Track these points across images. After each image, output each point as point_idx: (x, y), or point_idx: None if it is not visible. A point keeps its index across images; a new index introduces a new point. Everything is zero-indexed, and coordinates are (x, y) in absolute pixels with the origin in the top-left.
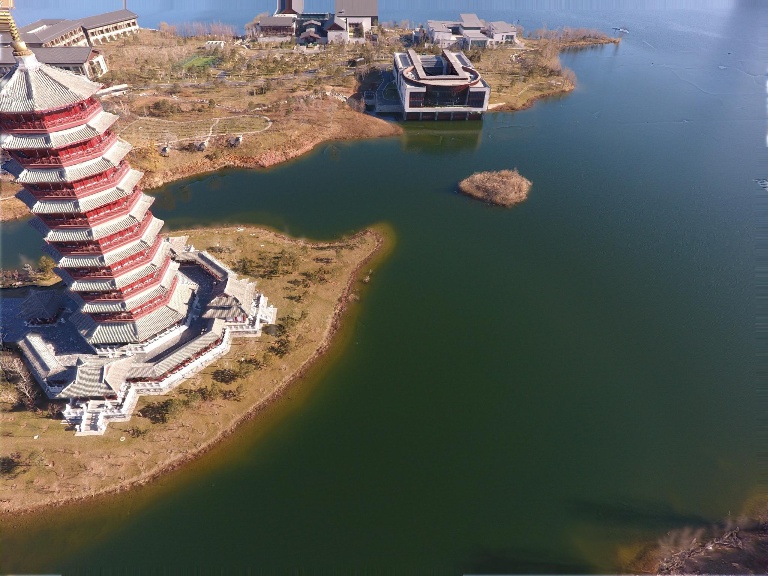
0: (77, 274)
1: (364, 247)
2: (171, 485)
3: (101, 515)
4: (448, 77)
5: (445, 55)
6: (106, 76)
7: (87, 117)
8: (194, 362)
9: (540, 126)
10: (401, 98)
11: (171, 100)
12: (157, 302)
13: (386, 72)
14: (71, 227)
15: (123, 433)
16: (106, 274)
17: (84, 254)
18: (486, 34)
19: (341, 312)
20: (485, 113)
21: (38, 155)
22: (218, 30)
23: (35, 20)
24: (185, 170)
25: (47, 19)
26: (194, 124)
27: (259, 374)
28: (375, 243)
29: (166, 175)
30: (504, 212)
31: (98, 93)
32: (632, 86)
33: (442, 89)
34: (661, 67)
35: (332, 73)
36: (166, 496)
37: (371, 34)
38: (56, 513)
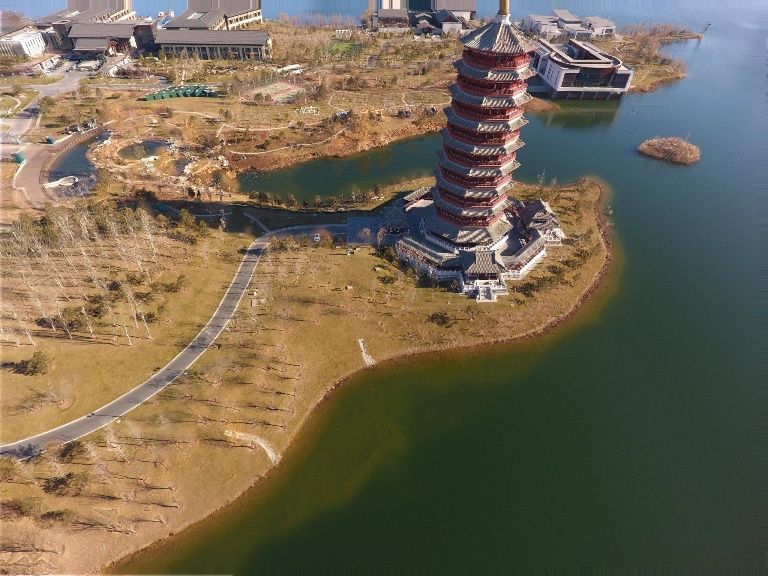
0: (472, 184)
1: (592, 191)
2: (560, 335)
3: (524, 351)
4: (594, 61)
5: (574, 44)
6: (276, 57)
7: None
8: (534, 258)
9: (674, 105)
10: (547, 80)
11: (348, 78)
12: (500, 214)
13: None
14: (491, 144)
15: (511, 301)
16: (492, 185)
17: (487, 167)
18: (585, 28)
19: (605, 234)
20: None
21: (495, 87)
22: (340, 20)
23: (187, 8)
24: (400, 133)
25: (196, 7)
26: (386, 97)
27: (577, 270)
28: (597, 188)
29: (387, 136)
30: (683, 170)
31: None
32: (735, 75)
33: (593, 71)
34: (753, 59)
35: None
36: (560, 342)
37: None
38: (492, 349)
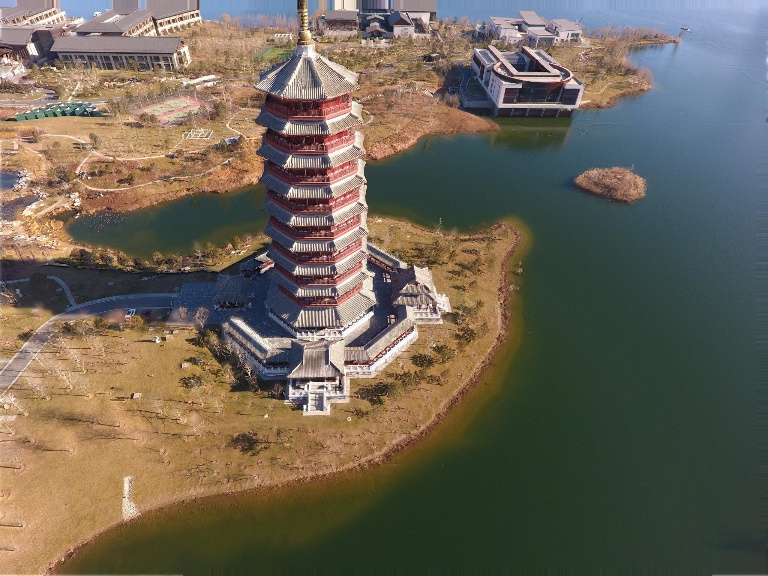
0: (301, 259)
1: (505, 240)
2: (405, 464)
3: (349, 491)
4: (541, 74)
5: (526, 52)
6: (192, 67)
7: (351, 106)
8: (394, 347)
9: (631, 124)
10: (490, 94)
11: None
12: (355, 288)
13: (463, 68)
14: (314, 213)
15: (348, 414)
16: (329, 259)
17: (316, 239)
18: (550, 32)
19: (506, 302)
20: (576, 110)
21: (304, 142)
22: (283, 23)
23: (108, 9)
24: None
25: (119, 8)
26: None
27: None
28: (513, 236)
29: None
30: (624, 208)
31: (190, 83)
32: (707, 86)
33: (538, 86)
34: (730, 68)
35: (414, 68)
36: (403, 474)
37: (440, 30)
38: (306, 488)
